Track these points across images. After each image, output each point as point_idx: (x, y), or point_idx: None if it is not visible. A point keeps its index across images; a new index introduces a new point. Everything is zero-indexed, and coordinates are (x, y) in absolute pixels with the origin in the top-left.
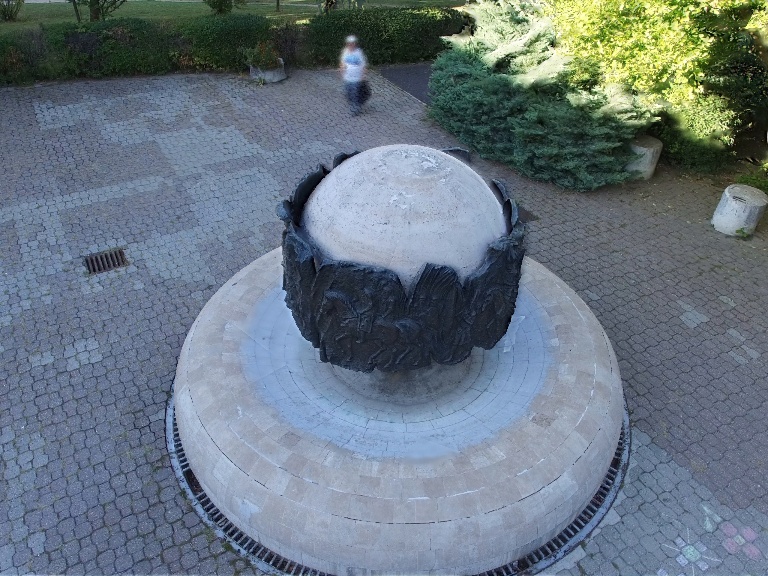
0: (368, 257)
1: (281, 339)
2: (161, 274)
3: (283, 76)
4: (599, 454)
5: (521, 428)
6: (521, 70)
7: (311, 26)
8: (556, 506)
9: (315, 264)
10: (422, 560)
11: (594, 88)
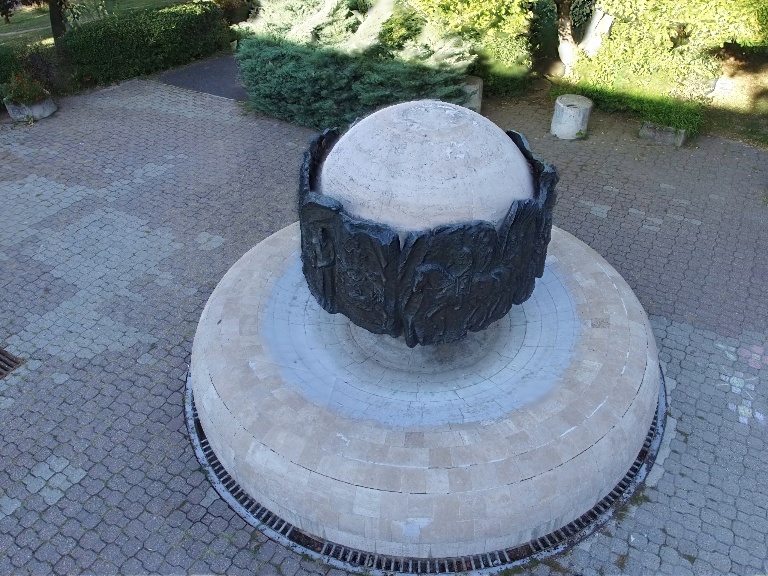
0: (449, 217)
1: (310, 356)
2: (79, 356)
3: (53, 108)
4: (652, 332)
5: (591, 337)
6: (332, 40)
7: (65, 45)
8: (656, 387)
9: (400, 242)
10: (595, 485)
11: (407, 42)
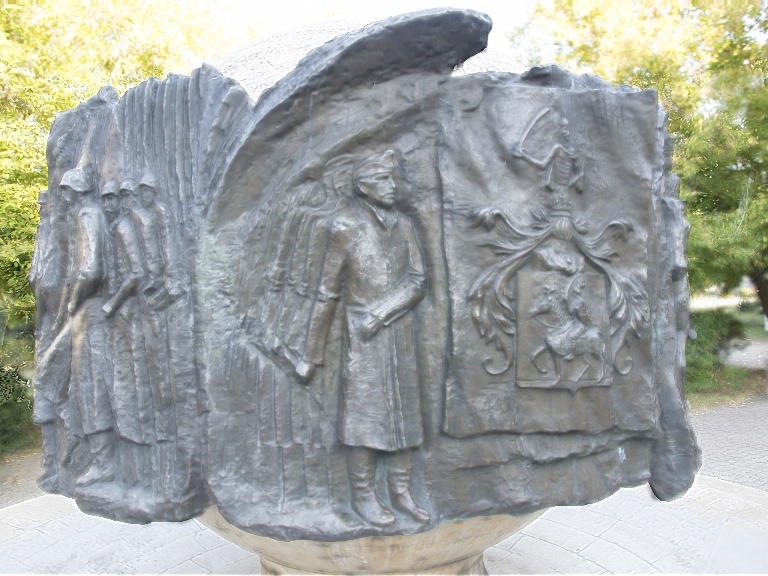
0: None
1: None
2: None
3: None
4: None
5: None
6: None
7: None
8: None
9: None
10: None
11: None
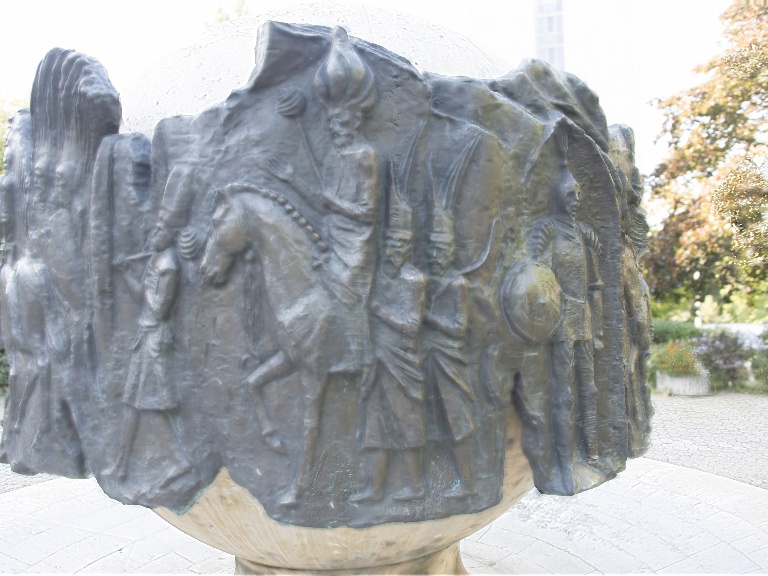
0: None
1: None
2: None
3: (707, 391)
4: None
5: None
6: None
7: (766, 334)
8: None
9: None
10: None
11: None
